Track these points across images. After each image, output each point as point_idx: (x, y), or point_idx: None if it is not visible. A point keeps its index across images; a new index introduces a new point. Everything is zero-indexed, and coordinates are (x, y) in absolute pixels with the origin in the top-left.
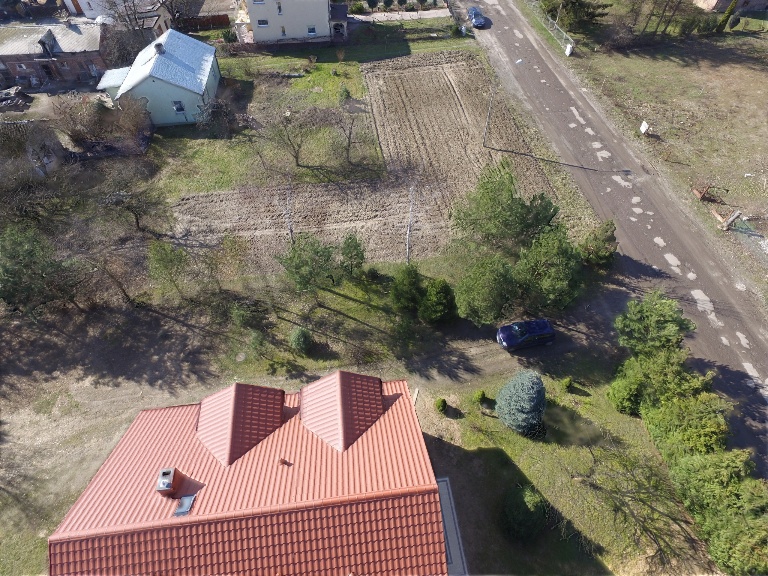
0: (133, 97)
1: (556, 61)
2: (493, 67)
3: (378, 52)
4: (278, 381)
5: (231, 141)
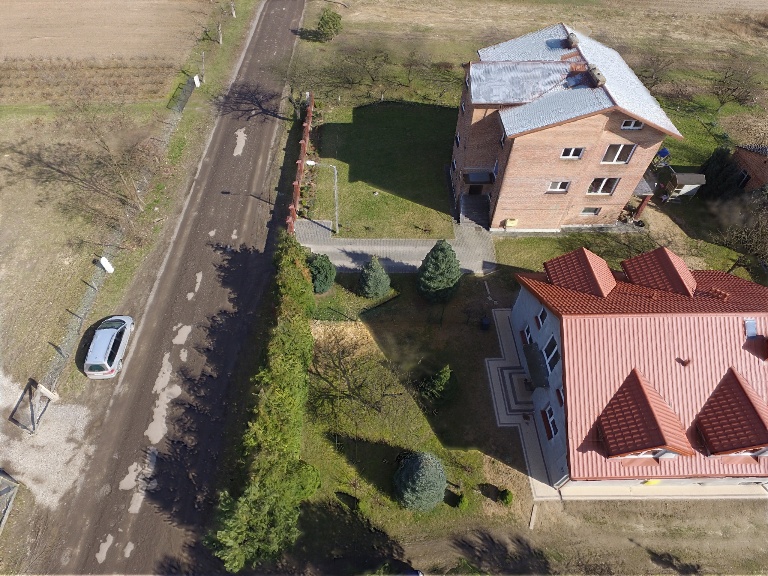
0: None
1: None
2: None
3: None
4: (708, 564)
5: None
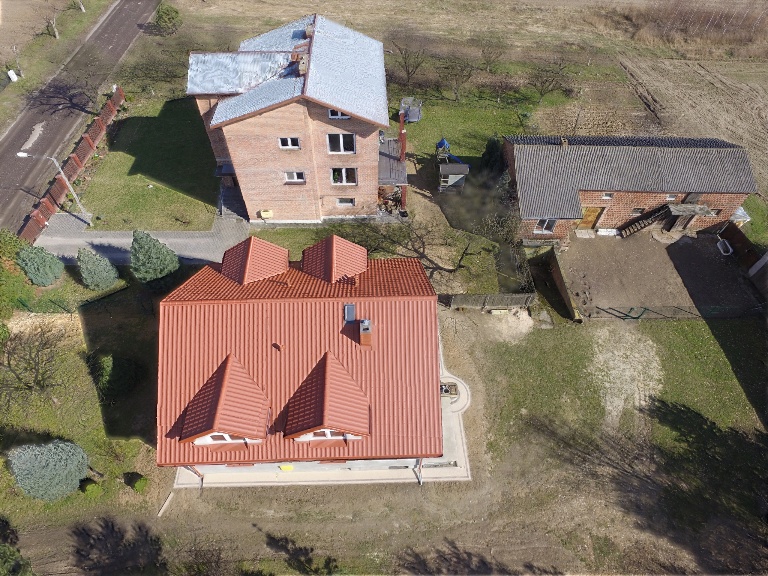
0: None
1: None
2: None
3: None
4: (323, 548)
5: None
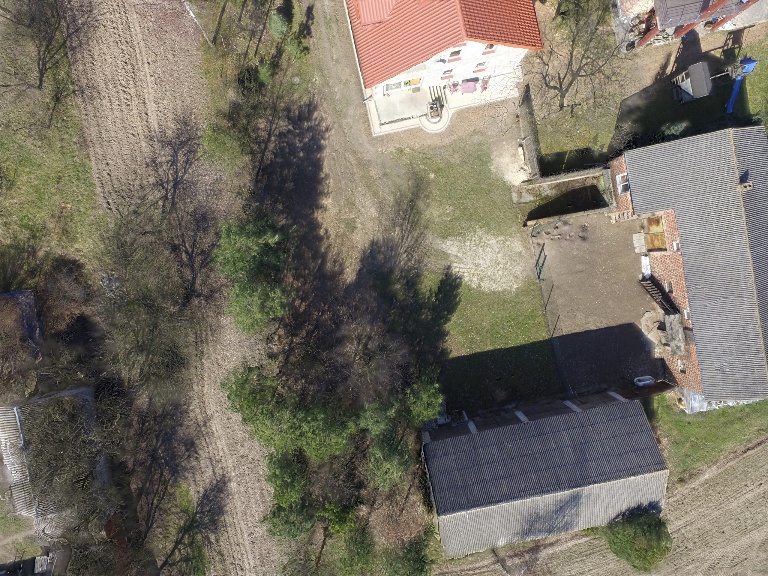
0: None
1: None
2: None
3: None
4: (314, 44)
5: None
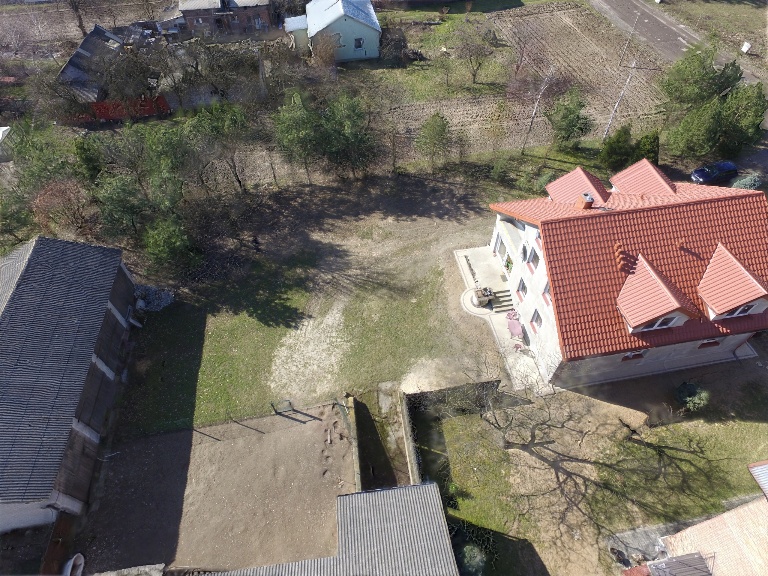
0: (326, 34)
1: (650, 7)
2: (600, 12)
3: (496, 5)
4: None
5: (407, 69)
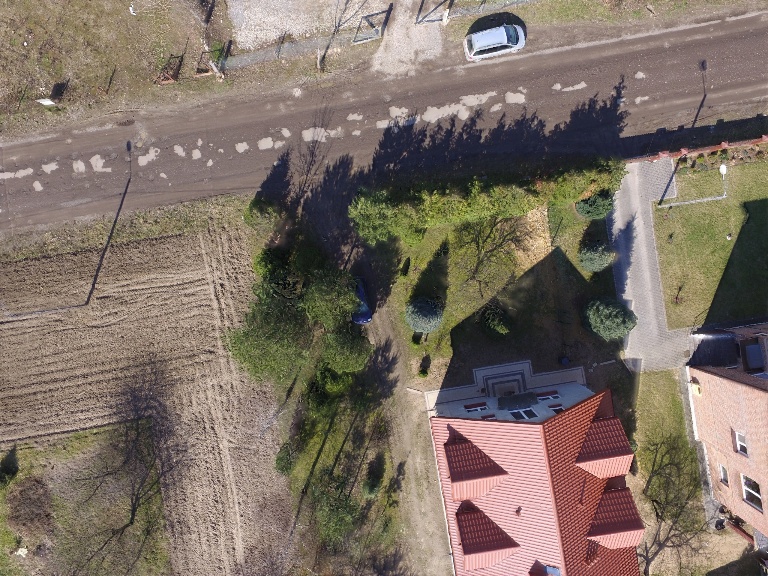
0: None
1: None
2: None
3: None
4: (403, 497)
5: None
